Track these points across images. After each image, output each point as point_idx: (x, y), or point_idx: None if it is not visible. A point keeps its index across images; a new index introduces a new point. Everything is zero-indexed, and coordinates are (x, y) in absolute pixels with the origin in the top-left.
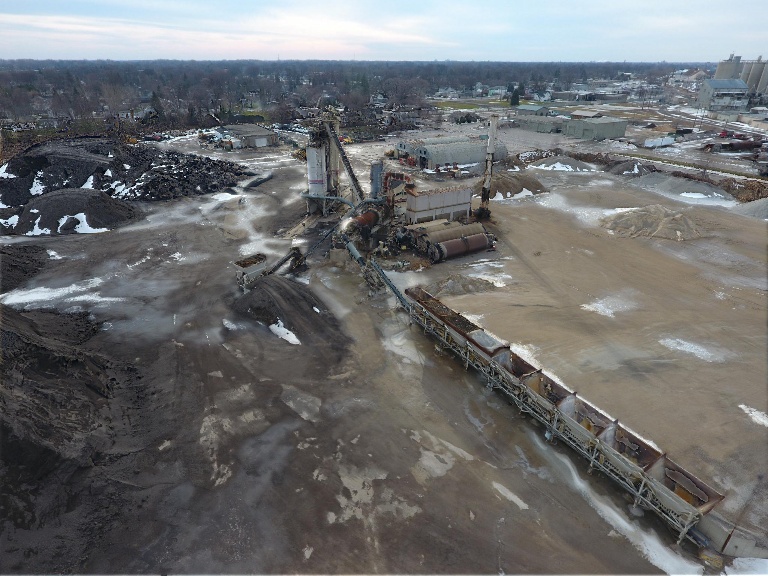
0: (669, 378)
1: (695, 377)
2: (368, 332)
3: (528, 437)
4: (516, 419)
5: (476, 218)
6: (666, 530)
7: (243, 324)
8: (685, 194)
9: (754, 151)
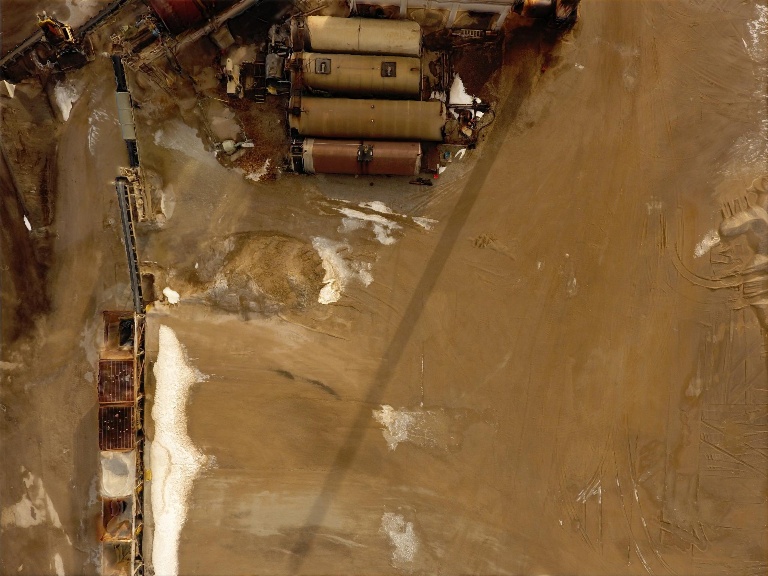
0: (309, 568)
1: (345, 575)
2: (78, 301)
3: None
4: None
5: None
6: None
7: None
8: None
9: None
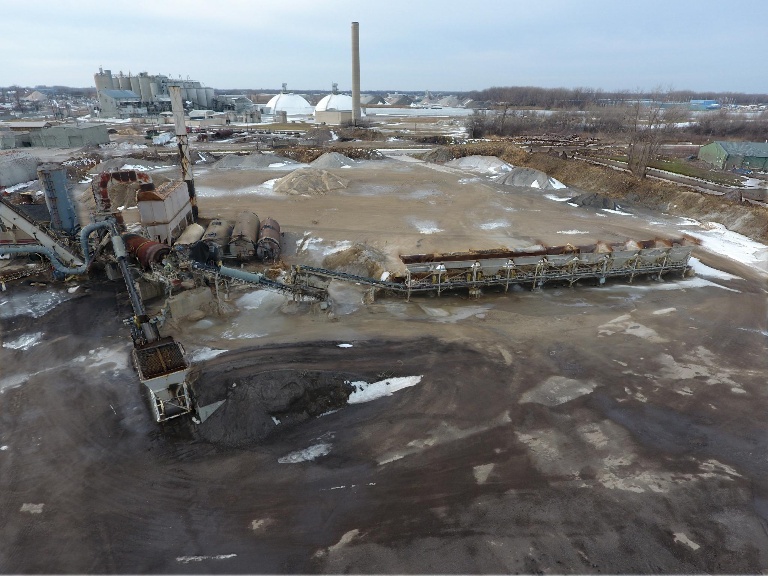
0: None
1: (529, 232)
2: (414, 325)
3: (597, 291)
4: (576, 290)
5: (189, 221)
6: (675, 276)
7: (319, 434)
8: (272, 165)
9: (232, 137)
